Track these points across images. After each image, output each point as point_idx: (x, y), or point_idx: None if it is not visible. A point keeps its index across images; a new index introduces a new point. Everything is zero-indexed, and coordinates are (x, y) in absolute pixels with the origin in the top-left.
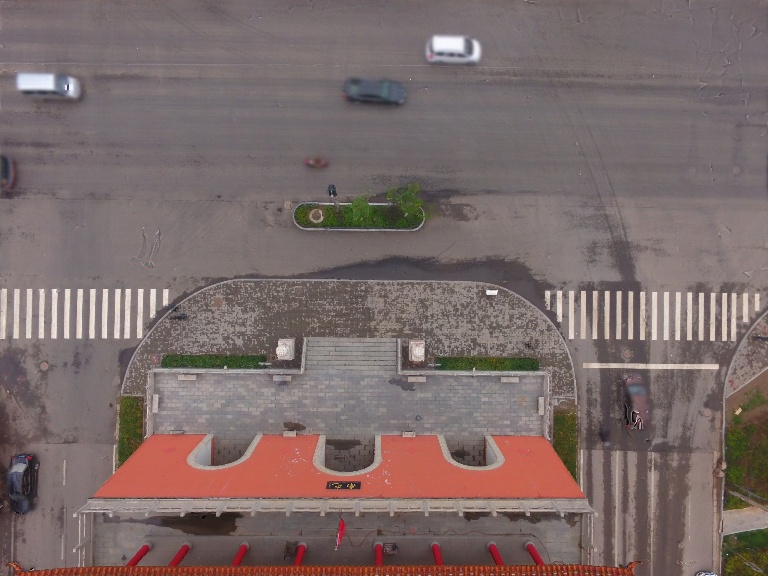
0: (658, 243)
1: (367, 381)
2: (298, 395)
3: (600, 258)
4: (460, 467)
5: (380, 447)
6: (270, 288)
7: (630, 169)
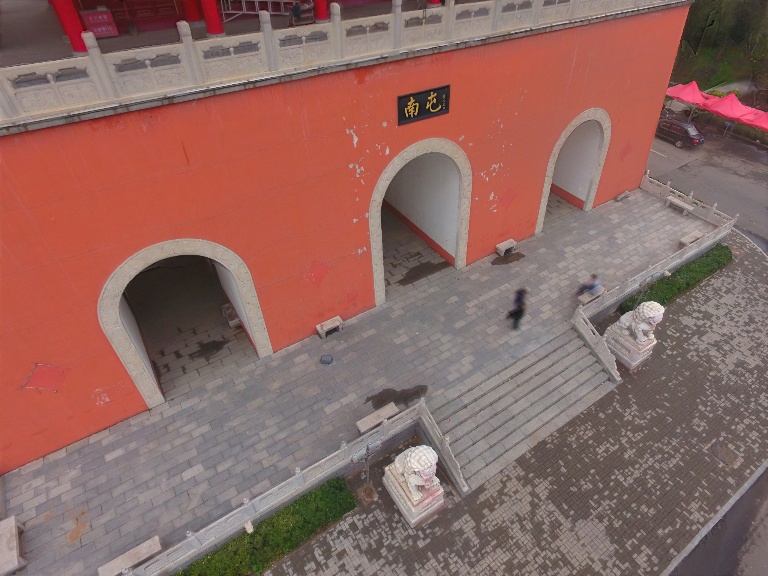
0: None
1: (465, 366)
2: (545, 292)
3: None
4: (210, 241)
5: (375, 262)
6: (767, 426)
7: None
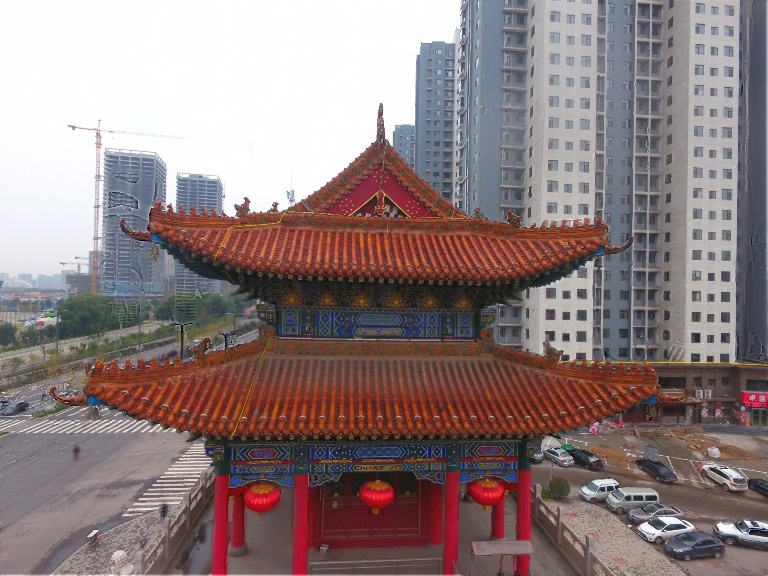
0: (125, 472)
1: None
2: None
3: (114, 493)
4: None
5: None
6: None
7: (47, 483)
